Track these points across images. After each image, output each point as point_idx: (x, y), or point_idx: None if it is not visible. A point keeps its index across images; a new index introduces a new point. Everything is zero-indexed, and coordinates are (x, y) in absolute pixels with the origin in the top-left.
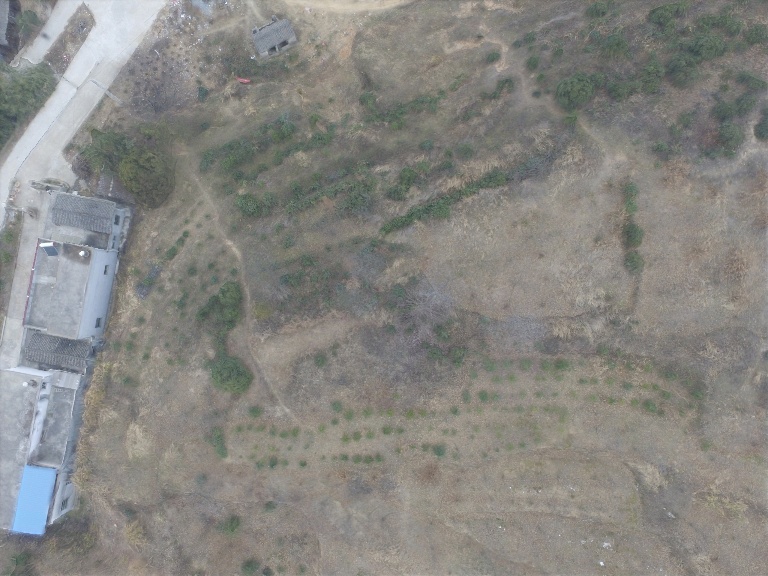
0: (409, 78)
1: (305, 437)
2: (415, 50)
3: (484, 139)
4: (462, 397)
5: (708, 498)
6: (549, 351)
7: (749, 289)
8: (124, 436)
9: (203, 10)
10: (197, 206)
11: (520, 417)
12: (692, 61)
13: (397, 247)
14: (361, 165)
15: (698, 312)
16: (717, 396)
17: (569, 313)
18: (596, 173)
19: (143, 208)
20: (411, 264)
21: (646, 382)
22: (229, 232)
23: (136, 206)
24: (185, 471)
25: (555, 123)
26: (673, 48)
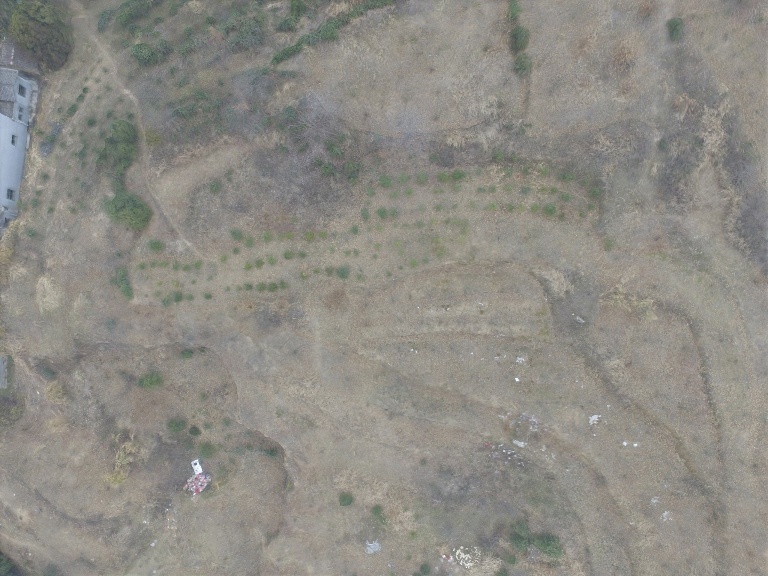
0: None
1: (208, 270)
2: None
3: None
4: (362, 217)
5: (614, 296)
6: (445, 162)
7: (639, 80)
8: (35, 293)
9: None
10: (96, 64)
11: (421, 232)
12: None
13: (288, 73)
14: (253, 4)
15: (590, 108)
16: (615, 192)
17: (464, 124)
18: None
19: (43, 70)
20: (302, 88)
21: (544, 185)
22: (127, 82)
23: (42, 78)
24: (95, 319)
25: None
26: None
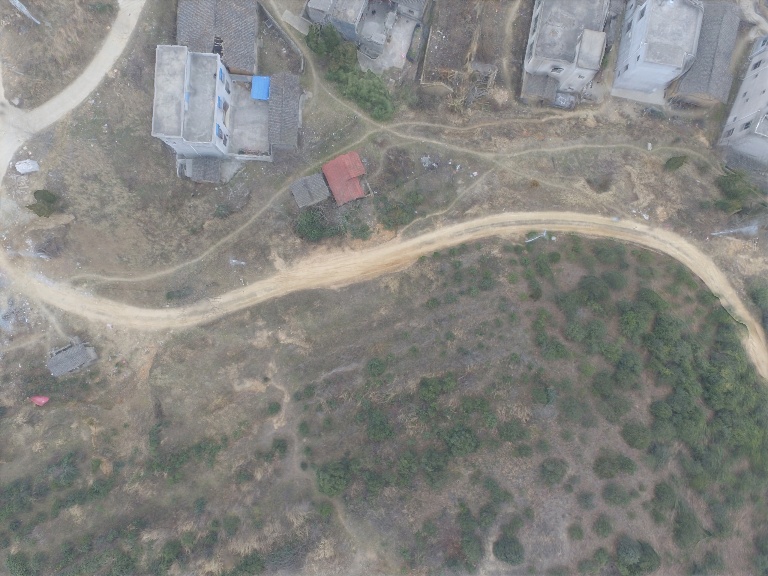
0: (198, 414)
1: None
2: (206, 384)
3: (252, 509)
4: None
5: None
6: None
7: None
8: None
9: (3, 327)
10: None
11: None
12: (440, 465)
13: None
14: (130, 530)
15: None
16: None
17: None
18: (346, 571)
19: None
20: None
21: None
22: None
23: None
24: None
25: (314, 507)
26: (431, 437)
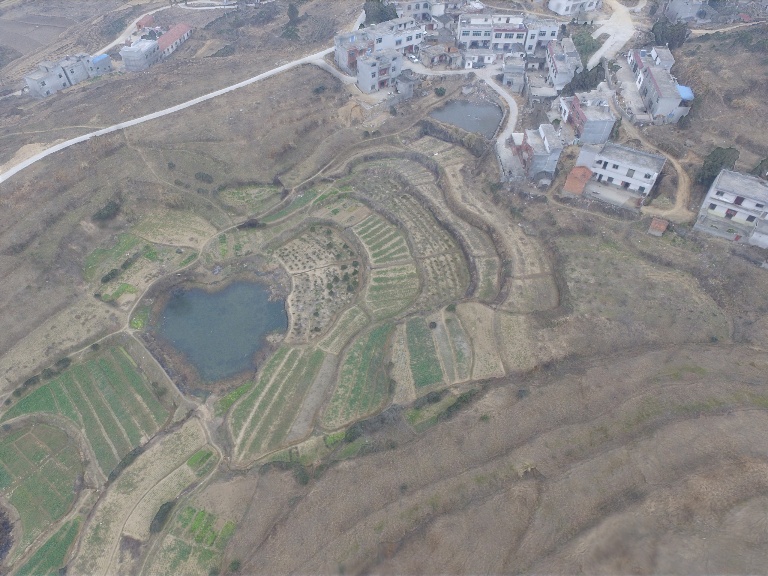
0: None
1: None
2: (745, 29)
3: None
4: None
5: None
6: None
7: None
8: None
9: None
10: None
11: None
12: None
13: None
14: None
15: None
16: None
17: None
18: None
19: (675, 46)
20: None
21: None
22: None
23: None
24: None
25: None
26: None
